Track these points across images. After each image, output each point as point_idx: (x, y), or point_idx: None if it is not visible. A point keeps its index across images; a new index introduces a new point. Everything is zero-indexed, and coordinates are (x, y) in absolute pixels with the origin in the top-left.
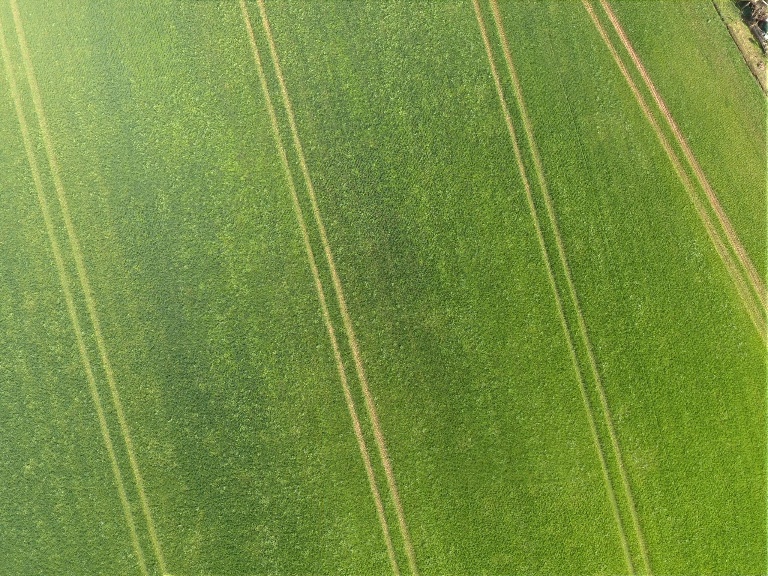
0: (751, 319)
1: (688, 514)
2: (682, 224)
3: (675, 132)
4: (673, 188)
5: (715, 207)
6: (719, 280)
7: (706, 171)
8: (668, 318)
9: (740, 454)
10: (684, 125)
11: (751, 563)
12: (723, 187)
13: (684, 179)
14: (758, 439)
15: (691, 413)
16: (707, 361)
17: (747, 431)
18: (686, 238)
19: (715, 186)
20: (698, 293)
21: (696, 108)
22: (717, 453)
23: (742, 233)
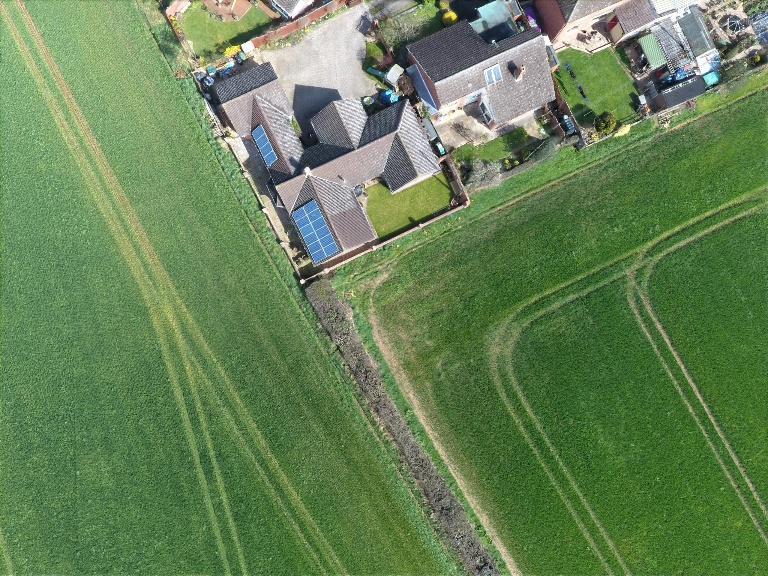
0: (98, 208)
1: (20, 398)
2: (27, 113)
3: (29, 24)
4: (20, 78)
5: (68, 98)
6: (65, 169)
7: (58, 63)
8: (5, 205)
9: (77, 340)
10: (37, 17)
11: (87, 448)
12: (76, 79)
13: (35, 70)
14: (98, 326)
15: (25, 298)
16: (45, 248)
17: (87, 318)
18: (31, 127)
19: (68, 78)
20: (40, 181)
21: (53, 1)
22: (53, 339)
23: (94, 124)
